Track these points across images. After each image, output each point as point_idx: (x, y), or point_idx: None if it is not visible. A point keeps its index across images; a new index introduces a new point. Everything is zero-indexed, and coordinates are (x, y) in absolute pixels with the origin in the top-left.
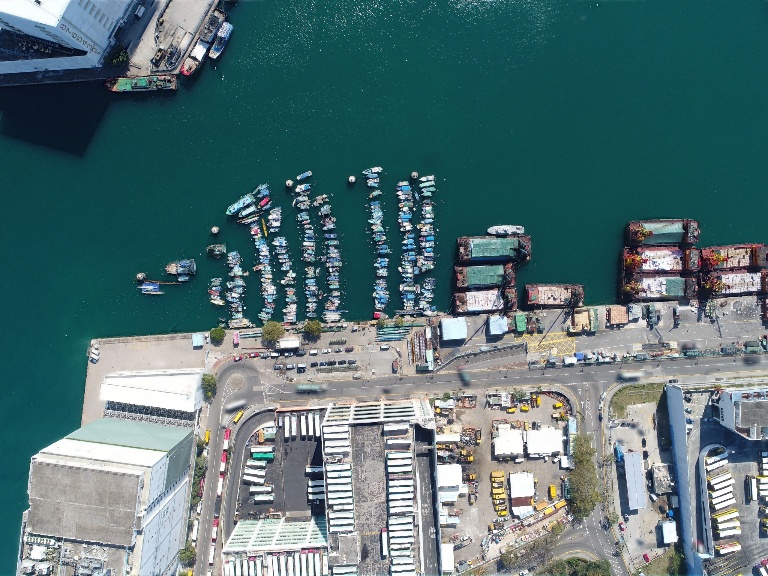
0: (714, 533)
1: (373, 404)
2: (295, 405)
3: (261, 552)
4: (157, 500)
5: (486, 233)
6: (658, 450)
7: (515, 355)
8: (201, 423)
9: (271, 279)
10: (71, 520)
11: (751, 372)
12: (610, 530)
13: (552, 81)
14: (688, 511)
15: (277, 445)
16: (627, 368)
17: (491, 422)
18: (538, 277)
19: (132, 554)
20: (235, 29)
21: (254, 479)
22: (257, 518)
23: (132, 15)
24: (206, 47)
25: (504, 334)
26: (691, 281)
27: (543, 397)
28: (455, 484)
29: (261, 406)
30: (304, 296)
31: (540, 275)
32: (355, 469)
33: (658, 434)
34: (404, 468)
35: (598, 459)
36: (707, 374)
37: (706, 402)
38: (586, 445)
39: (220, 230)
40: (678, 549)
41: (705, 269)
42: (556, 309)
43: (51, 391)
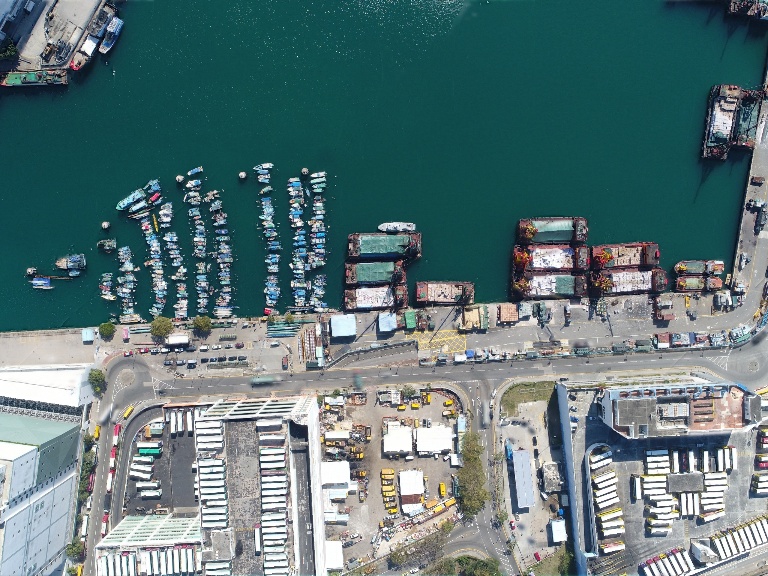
0: (599, 532)
1: (260, 400)
2: (185, 401)
3: (134, 547)
4: (26, 494)
5: (377, 230)
6: (549, 448)
7: (406, 352)
8: (91, 418)
9: (162, 274)
10: None
11: (642, 371)
12: (501, 528)
13: (443, 78)
14: (575, 510)
15: (165, 441)
16: (518, 366)
17: (382, 419)
18: (429, 274)
19: None
20: (126, 24)
21: (140, 475)
22: (145, 514)
23: (22, 9)
24: (96, 42)
25: (395, 331)
26: (580, 279)
27: (434, 394)
28: (343, 481)
29: (151, 402)
30: (195, 292)
31: (431, 272)
32: (229, 465)
33: (549, 432)
34: (276, 464)
35: (489, 457)
36: (598, 373)
37: (591, 400)
38: (474, 443)
39: (111, 225)
40: (569, 548)
41: (596, 267)
42: (447, 306)
43: None
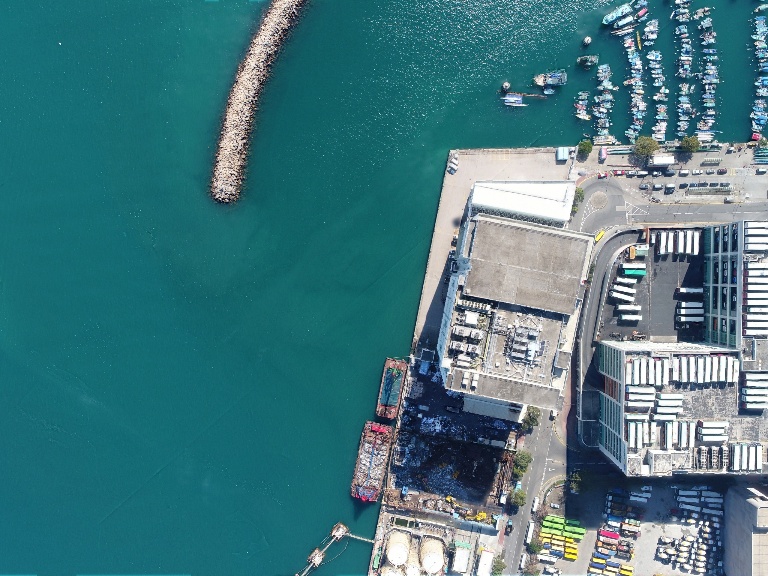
0: None
1: None
2: None
3: (667, 353)
4: None
5: None
6: None
7: None
8: None
9: (642, 95)
10: (512, 284)
11: None
12: None
13: None
14: None
15: None
16: None
17: None
18: None
19: (565, 328)
20: None
21: (624, 296)
22: (619, 340)
23: None
24: None
25: None
26: None
27: None
28: None
29: (623, 227)
30: (675, 114)
31: None
32: None
33: None
34: None
35: None
36: None
37: None
38: None
39: (591, 42)
40: None
41: None
42: None
43: (403, 202)
